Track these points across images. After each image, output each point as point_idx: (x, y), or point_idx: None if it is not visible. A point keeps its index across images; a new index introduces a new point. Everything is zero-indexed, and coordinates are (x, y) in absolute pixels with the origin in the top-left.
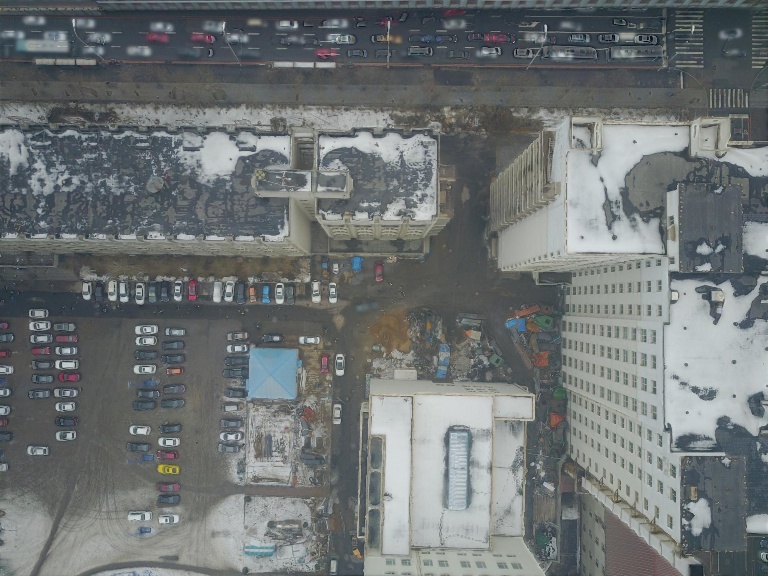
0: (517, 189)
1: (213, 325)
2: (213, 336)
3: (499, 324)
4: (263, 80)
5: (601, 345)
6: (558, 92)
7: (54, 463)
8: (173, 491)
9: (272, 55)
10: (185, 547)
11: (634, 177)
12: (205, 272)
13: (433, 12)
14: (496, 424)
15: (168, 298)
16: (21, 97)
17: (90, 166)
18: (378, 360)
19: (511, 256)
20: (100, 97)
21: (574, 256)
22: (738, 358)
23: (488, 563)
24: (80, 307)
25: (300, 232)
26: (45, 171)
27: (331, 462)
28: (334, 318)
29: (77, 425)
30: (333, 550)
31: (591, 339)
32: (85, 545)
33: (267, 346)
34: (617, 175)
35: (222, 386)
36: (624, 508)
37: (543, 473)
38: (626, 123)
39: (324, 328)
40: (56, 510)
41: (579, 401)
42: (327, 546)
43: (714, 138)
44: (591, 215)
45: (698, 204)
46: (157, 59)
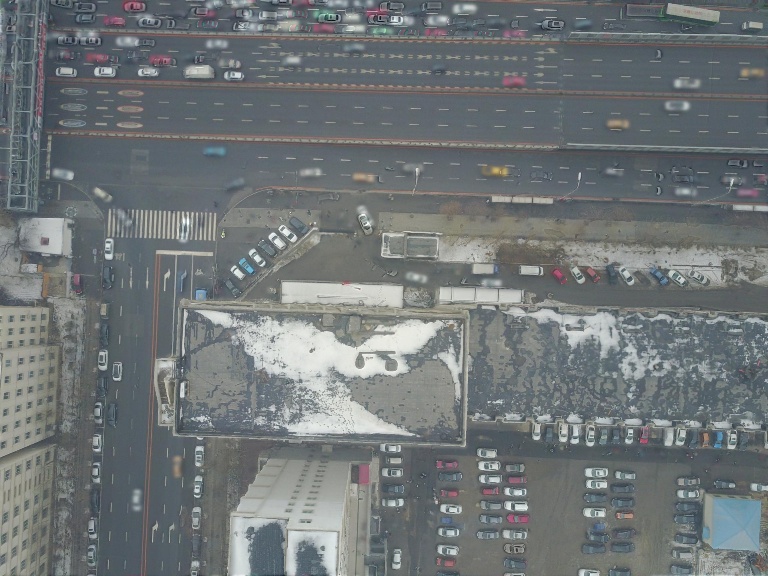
0: None
1: (662, 468)
2: (661, 479)
3: None
4: (715, 221)
5: None
6: None
7: None
8: None
9: None
10: None
11: None
12: None
13: None
14: None
15: (619, 441)
16: (468, 232)
17: (682, 351)
18: None
19: None
20: None
21: None
22: None
23: None
24: (526, 446)
25: None
26: (636, 355)
27: None
28: None
29: None
30: None
31: None
32: None
33: (718, 492)
34: None
35: (671, 531)
36: None
37: None
38: None
39: None
40: None
41: None
42: None
43: None
44: None
45: None
46: (605, 196)
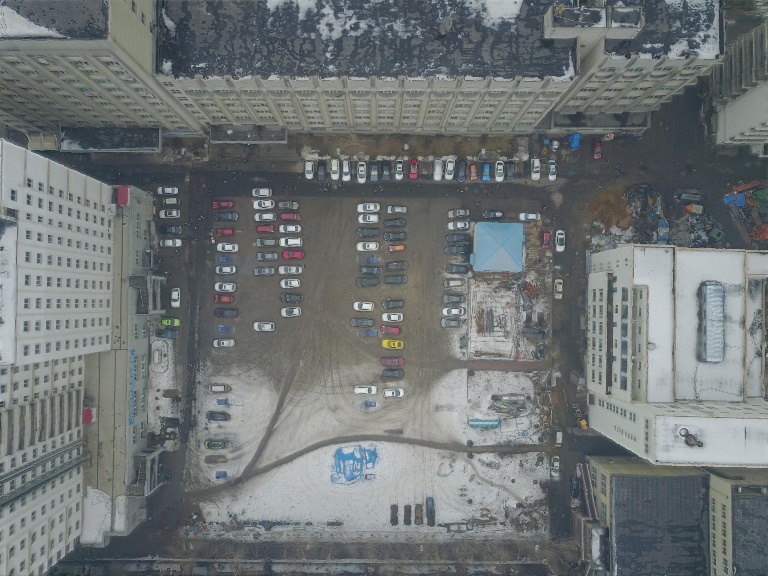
0: None
1: (433, 203)
2: (433, 214)
3: (717, 200)
4: None
5: None
6: None
7: (279, 339)
8: (398, 365)
9: None
10: (409, 421)
11: None
12: (424, 151)
13: None
14: None
15: (389, 176)
16: None
17: (377, 11)
18: (598, 236)
19: (752, 119)
20: None
21: None
22: None
23: (755, 408)
24: (301, 187)
25: None
26: (333, 16)
27: (552, 336)
28: (552, 195)
29: (302, 302)
30: (556, 423)
31: None
32: (311, 419)
33: None
34: None
35: (443, 263)
36: None
37: None
38: None
39: (543, 205)
40: (282, 385)
41: None
42: (550, 419)
43: None
44: None
45: None
46: None
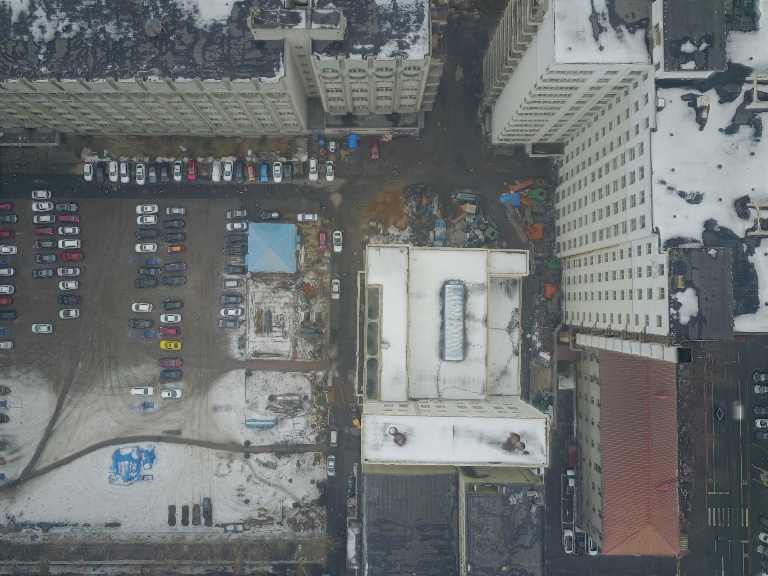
0: (508, 34)
1: (212, 204)
2: (213, 215)
3: (494, 199)
4: None
5: (593, 192)
6: None
7: (58, 341)
8: (175, 366)
9: None
10: (188, 422)
11: None
12: (204, 153)
13: None
14: (491, 286)
15: (168, 178)
16: None
17: (90, 13)
18: (375, 236)
19: (504, 119)
20: None
21: (562, 68)
22: (724, 163)
23: (484, 406)
24: (82, 189)
25: (296, 90)
26: (46, 18)
27: (330, 336)
28: (331, 196)
29: (80, 303)
30: (333, 422)
31: (583, 192)
32: (89, 421)
33: None
34: None
35: (222, 264)
36: (616, 338)
37: (539, 344)
38: None
39: (322, 206)
40: (61, 387)
41: (573, 264)
42: (327, 418)
43: None
44: (578, 27)
45: (682, 4)
46: None
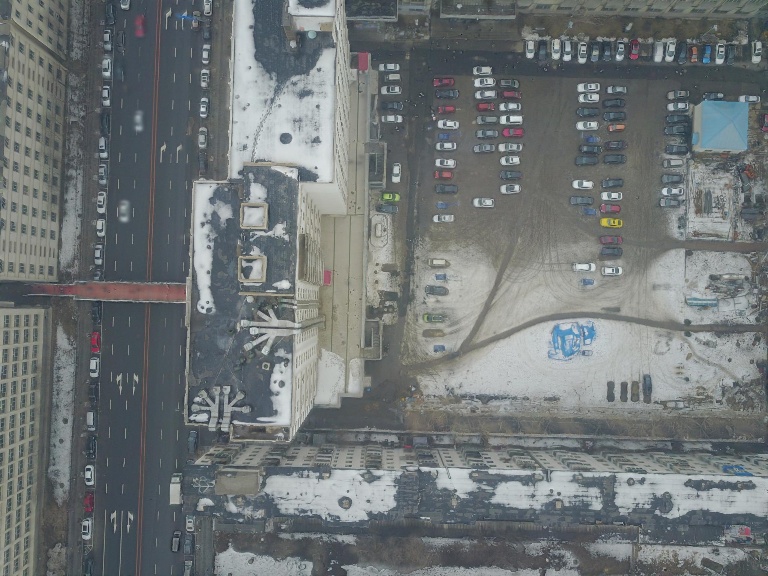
0: None
1: (652, 85)
2: (652, 96)
3: None
4: None
5: None
6: None
7: (498, 216)
8: (617, 243)
9: None
10: (627, 299)
11: None
12: (644, 33)
13: None
14: None
15: (610, 57)
16: None
17: None
18: None
19: None
20: None
21: None
22: None
23: None
24: (521, 67)
25: None
26: None
27: None
28: None
29: (521, 179)
30: None
31: None
32: (529, 296)
33: None
34: None
35: (662, 144)
36: None
37: None
38: None
39: (762, 89)
40: (500, 262)
41: None
42: None
43: None
44: None
45: None
46: None
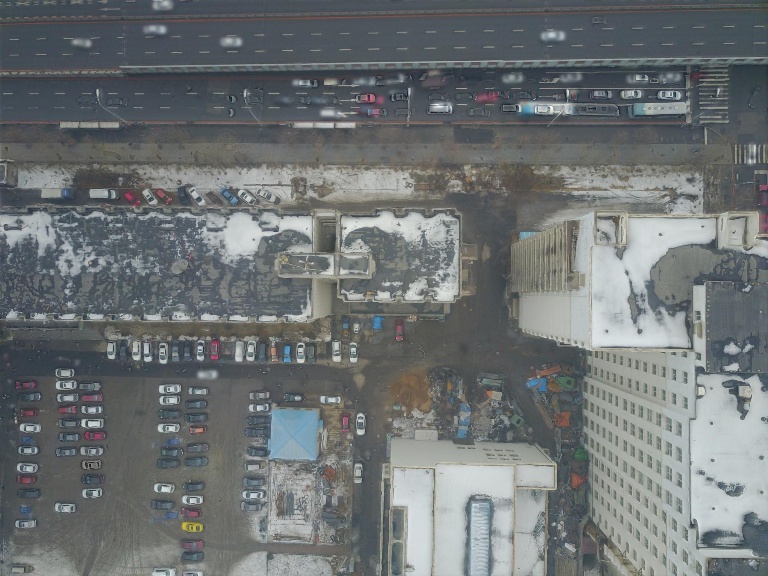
0: (539, 265)
1: (235, 384)
2: (235, 395)
3: (520, 383)
4: (283, 140)
5: (624, 419)
6: (579, 149)
7: (81, 520)
8: (197, 548)
9: (292, 115)
10: None
11: (660, 270)
12: (227, 331)
13: (453, 70)
14: (517, 489)
15: (191, 358)
16: (46, 159)
17: (116, 247)
18: (399, 419)
19: (533, 323)
20: (123, 158)
21: None
22: (766, 454)
23: None
24: (105, 366)
25: (322, 303)
26: (72, 252)
27: (352, 521)
28: (355, 377)
29: (103, 483)
30: None
31: (614, 410)
32: None
33: (288, 405)
34: (642, 268)
35: (244, 445)
36: None
37: (564, 533)
38: (651, 216)
39: (345, 387)
40: (83, 566)
41: (601, 466)
42: None
43: (742, 230)
44: (616, 309)
45: (725, 303)
46: (179, 120)
